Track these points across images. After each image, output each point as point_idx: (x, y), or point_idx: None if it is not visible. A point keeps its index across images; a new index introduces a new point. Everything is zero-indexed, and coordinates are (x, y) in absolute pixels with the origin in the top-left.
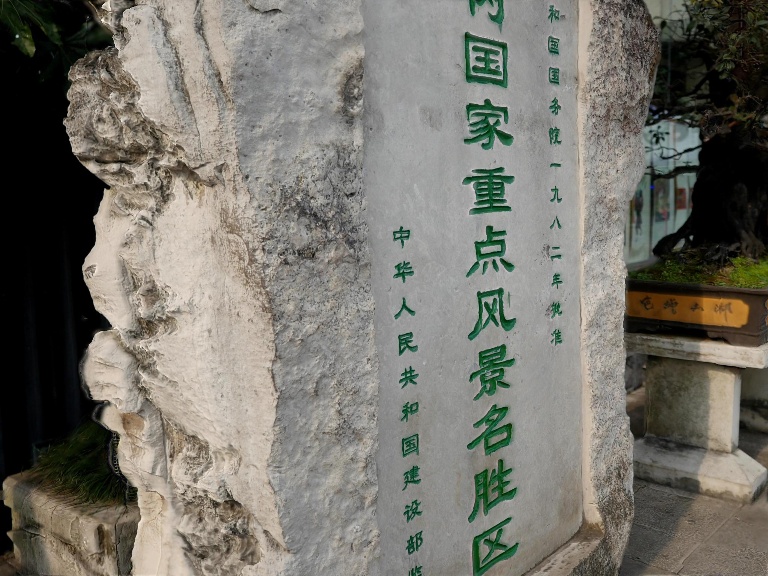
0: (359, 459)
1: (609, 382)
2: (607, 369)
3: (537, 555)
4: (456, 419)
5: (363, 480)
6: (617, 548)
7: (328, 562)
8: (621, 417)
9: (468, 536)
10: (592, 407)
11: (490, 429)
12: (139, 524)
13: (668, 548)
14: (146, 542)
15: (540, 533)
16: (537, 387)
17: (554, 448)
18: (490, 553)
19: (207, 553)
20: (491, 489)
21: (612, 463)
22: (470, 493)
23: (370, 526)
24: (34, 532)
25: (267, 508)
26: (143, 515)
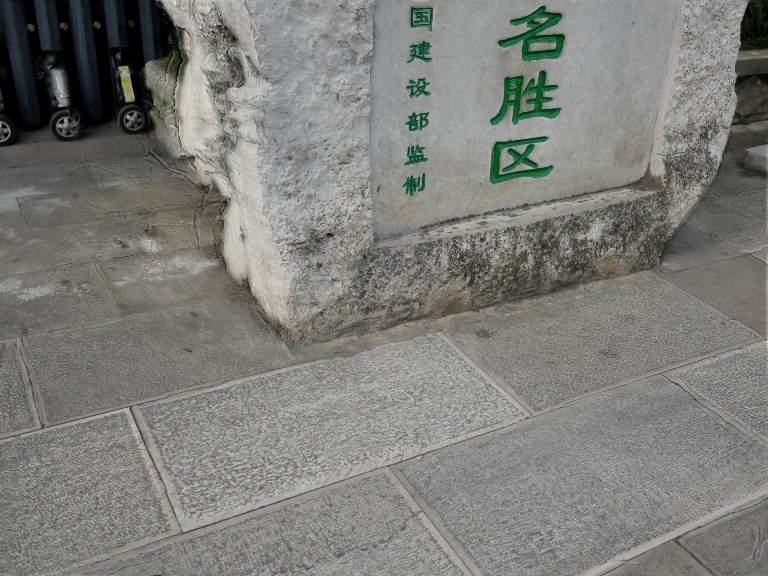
0: (350, 9)
1: (717, 24)
2: (717, 7)
3: (577, 187)
4: (487, 7)
5: (354, 33)
6: (678, 207)
7: (310, 104)
8: (727, 72)
9: (488, 138)
10: (683, 47)
11: (534, 33)
12: (181, 66)
13: (757, 234)
14: (182, 80)
15: (585, 166)
16: (609, 3)
17: (622, 81)
18: (515, 164)
19: (222, 90)
20: (526, 99)
21: (700, 120)
22: (497, 94)
23: (360, 83)
24: (148, 101)
25: (246, 32)
26: (184, 58)
